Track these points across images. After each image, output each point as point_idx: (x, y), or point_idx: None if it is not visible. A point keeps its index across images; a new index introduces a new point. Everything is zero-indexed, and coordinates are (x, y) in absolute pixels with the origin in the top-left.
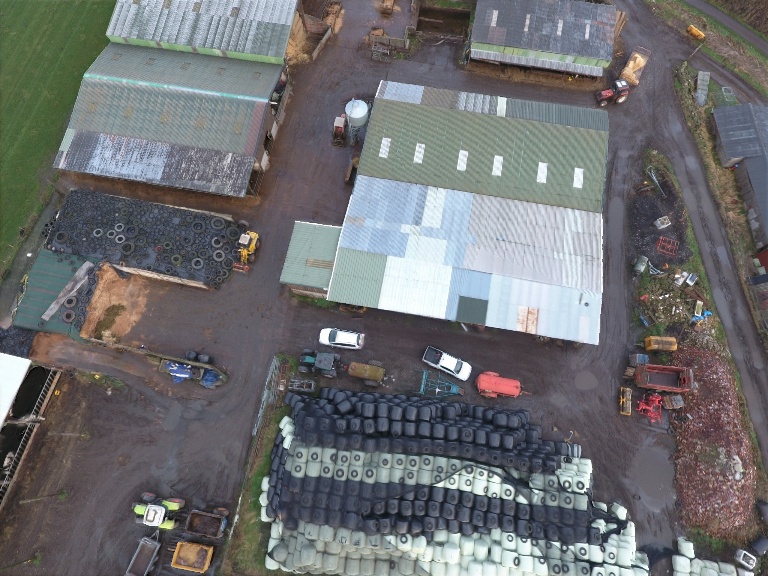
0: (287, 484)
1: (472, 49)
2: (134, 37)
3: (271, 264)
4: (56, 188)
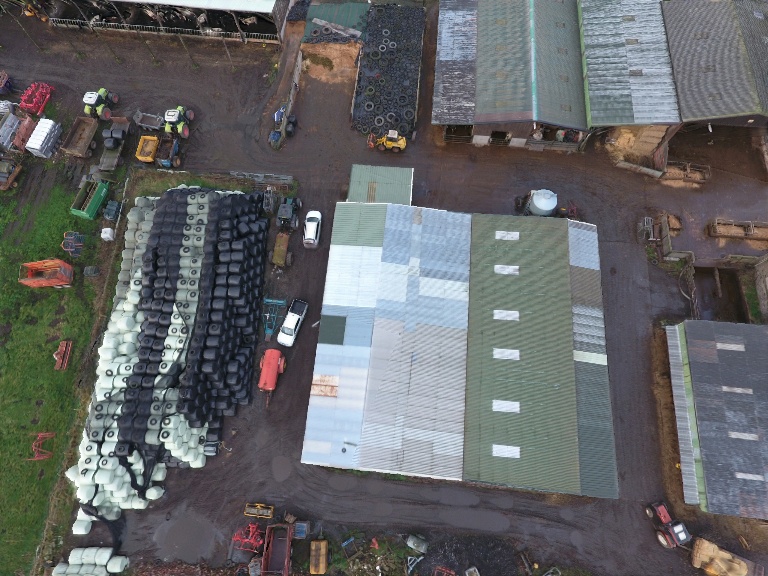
0: (185, 194)
1: (677, 326)
2: (583, 5)
3: (379, 164)
4: (427, 0)
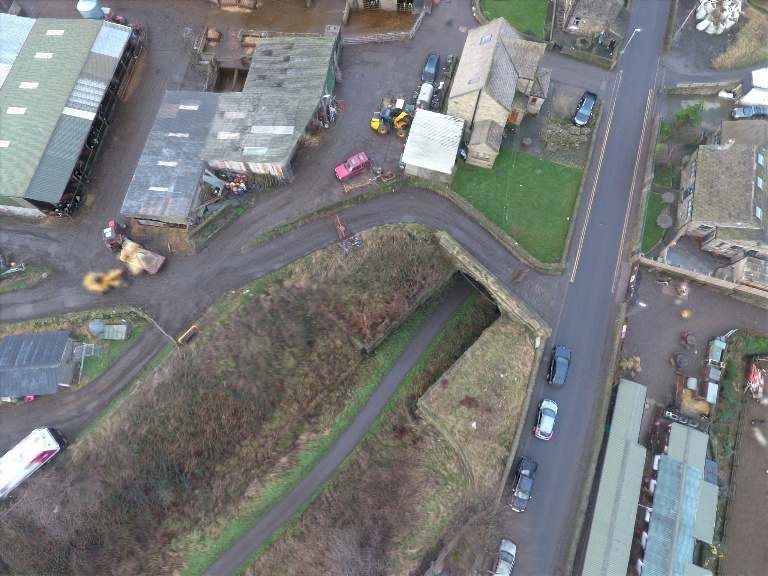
0: None
1: None
2: None
3: None
4: None
